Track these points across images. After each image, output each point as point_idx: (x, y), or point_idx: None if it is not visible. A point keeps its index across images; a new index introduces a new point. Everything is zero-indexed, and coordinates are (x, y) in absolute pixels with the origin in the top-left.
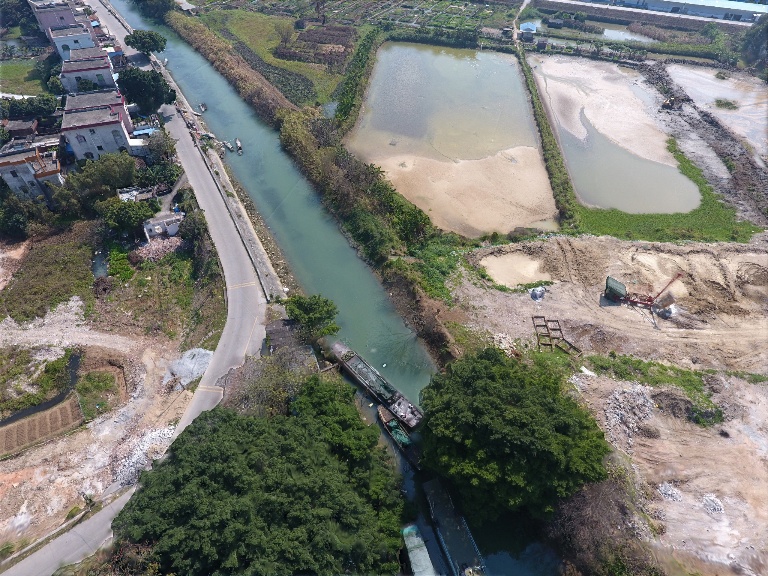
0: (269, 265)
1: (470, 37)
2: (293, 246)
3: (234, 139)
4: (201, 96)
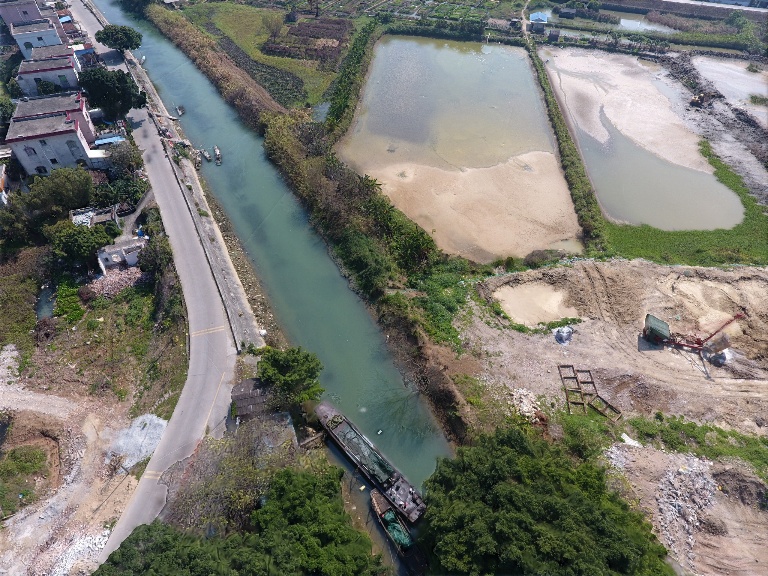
0: (244, 301)
1: (475, 29)
2: (274, 276)
3: (212, 147)
4: (179, 98)
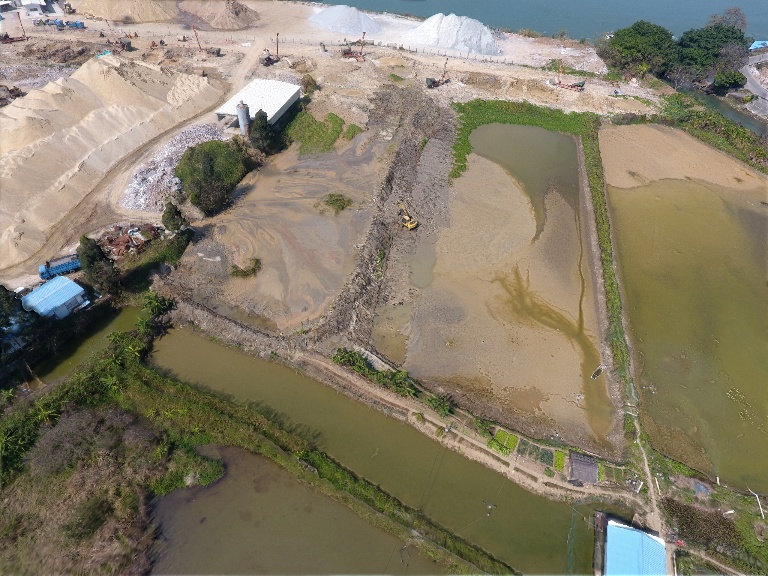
0: None
1: None
2: None
3: None
4: None
